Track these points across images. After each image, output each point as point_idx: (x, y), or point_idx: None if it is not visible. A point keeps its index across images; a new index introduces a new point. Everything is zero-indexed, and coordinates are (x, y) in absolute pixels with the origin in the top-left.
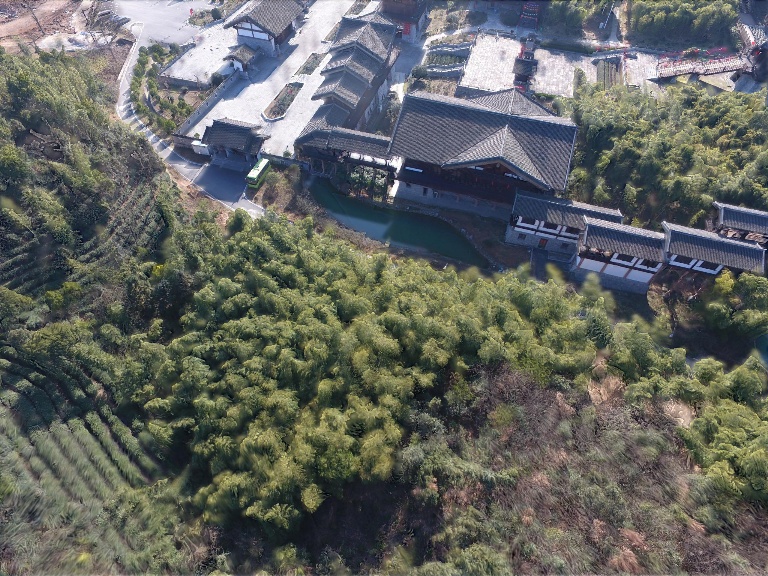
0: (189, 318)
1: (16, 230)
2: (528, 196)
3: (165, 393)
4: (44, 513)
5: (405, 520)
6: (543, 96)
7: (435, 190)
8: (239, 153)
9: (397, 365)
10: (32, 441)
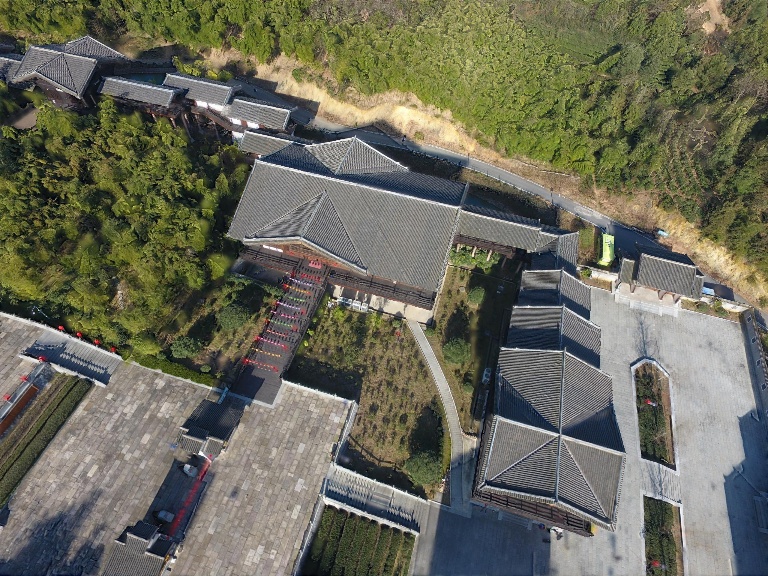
0: None
1: None
2: None
3: None
4: None
5: None
6: (205, 368)
7: None
8: None
9: None
10: None
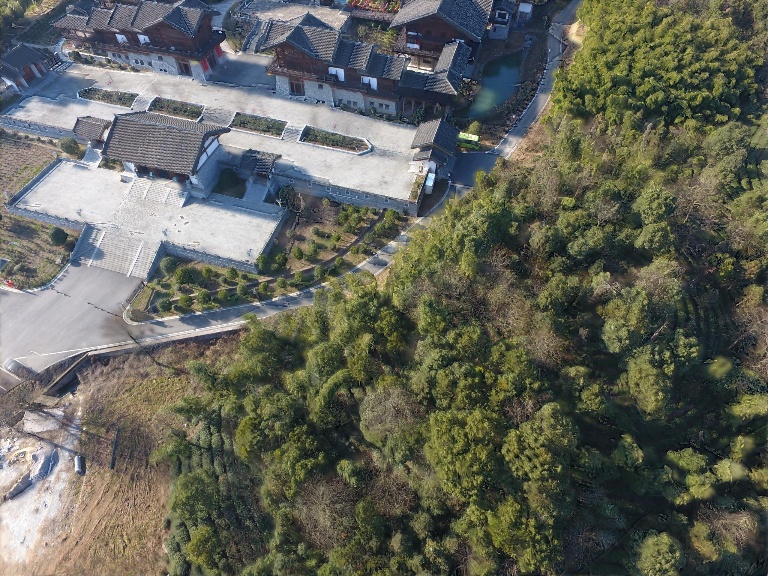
0: None
1: None
2: (501, 3)
3: None
4: None
5: None
6: None
7: None
8: None
9: None
10: None
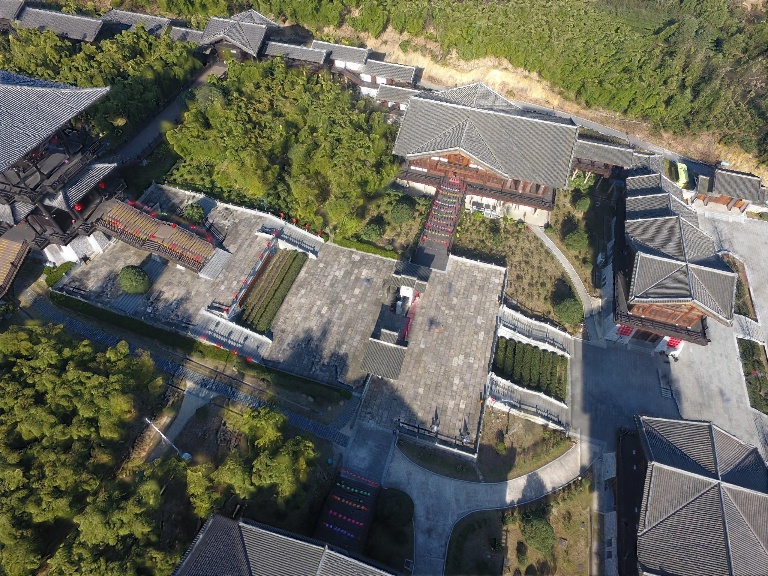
0: None
1: None
2: None
3: None
4: (638, 2)
5: None
6: (389, 246)
7: None
8: None
9: None
10: None
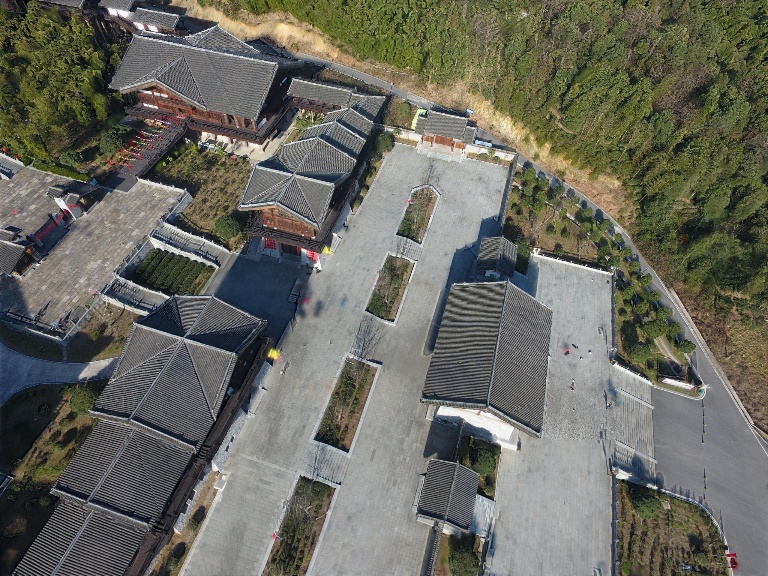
0: None
1: None
2: None
3: None
4: None
5: None
6: (83, 170)
7: None
8: None
9: None
10: None
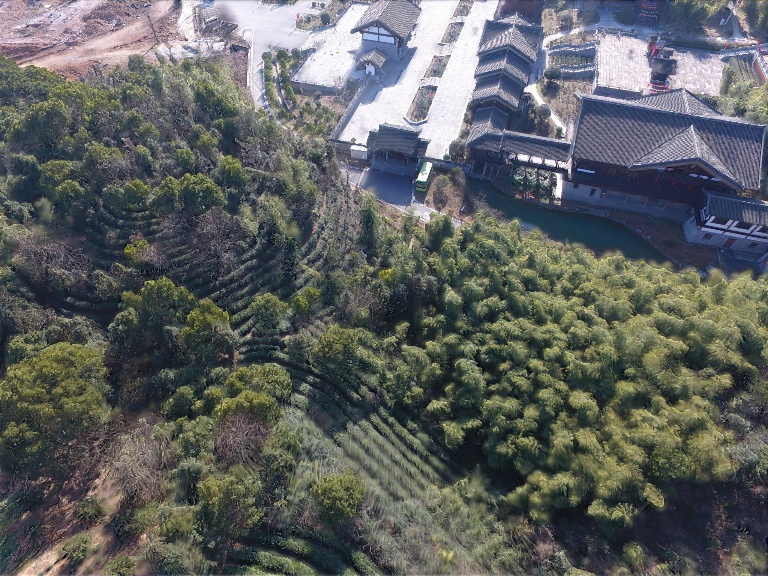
0: (440, 321)
1: (242, 237)
2: (720, 196)
3: (433, 395)
4: (386, 512)
5: (732, 518)
6: None
7: (604, 191)
8: (401, 157)
9: (682, 366)
10: (337, 442)
